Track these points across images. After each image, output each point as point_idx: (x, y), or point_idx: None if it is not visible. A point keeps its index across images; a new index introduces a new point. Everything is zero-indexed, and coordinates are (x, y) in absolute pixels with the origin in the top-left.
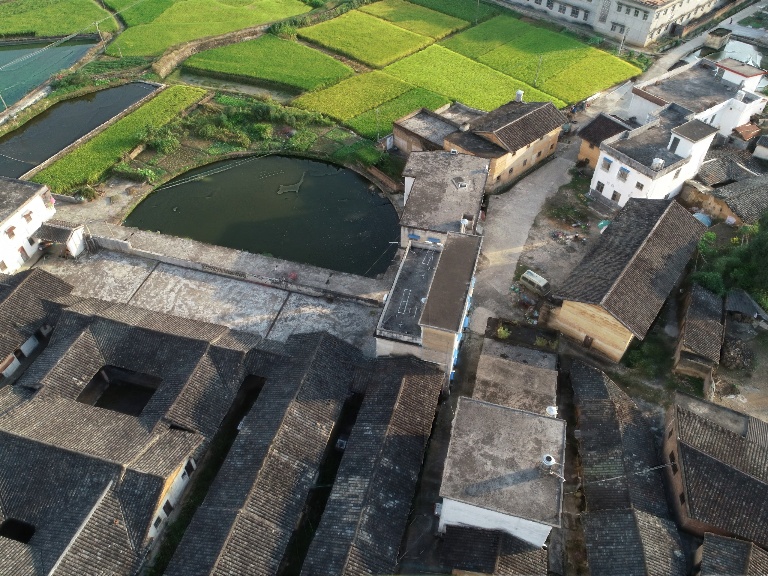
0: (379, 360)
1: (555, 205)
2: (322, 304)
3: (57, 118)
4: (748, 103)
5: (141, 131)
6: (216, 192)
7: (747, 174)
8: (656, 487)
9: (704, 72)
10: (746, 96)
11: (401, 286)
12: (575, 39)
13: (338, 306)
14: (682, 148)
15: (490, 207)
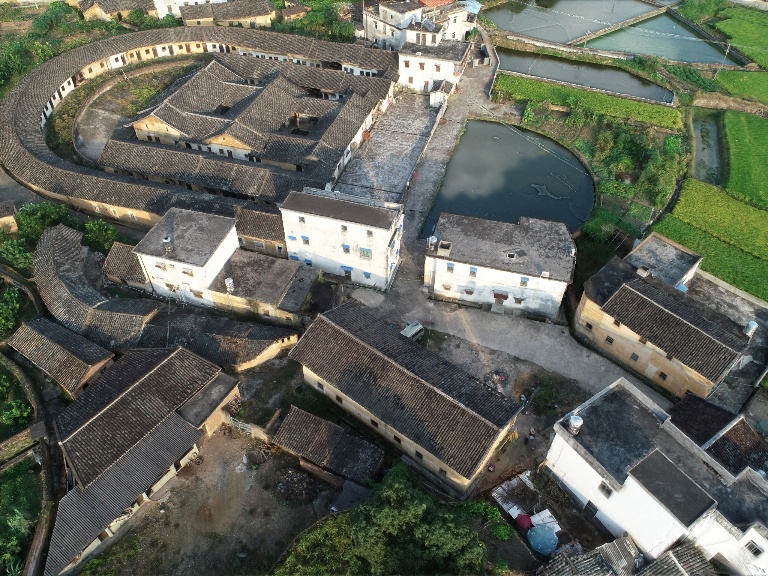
0: None
1: (561, 385)
2: None
3: (605, 75)
4: None
5: None
6: (526, 155)
7: None
8: None
9: None
10: None
11: None
12: None
13: None
14: None
15: (543, 324)
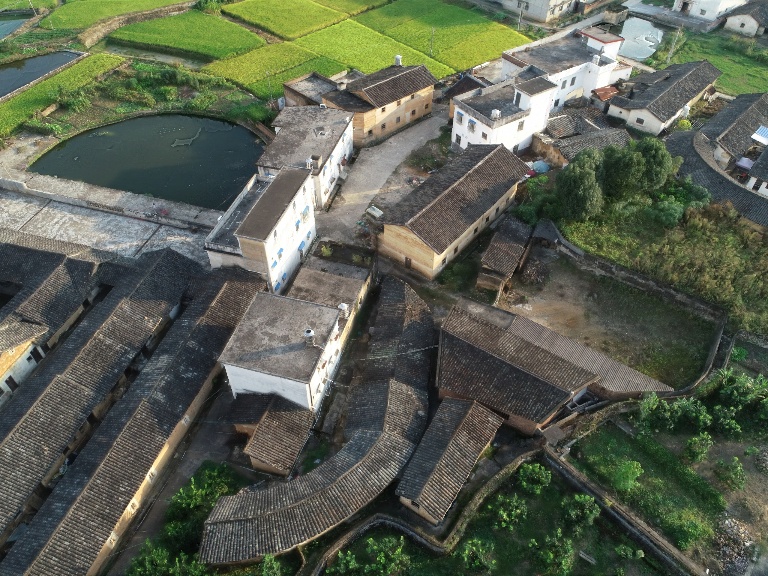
0: (213, 272)
1: (418, 156)
2: (187, 234)
3: None
4: (602, 66)
5: (53, 91)
6: (117, 145)
7: (591, 128)
8: (422, 368)
9: (575, 40)
10: (605, 61)
11: None
12: (481, 15)
13: (200, 236)
14: (523, 102)
15: (359, 157)
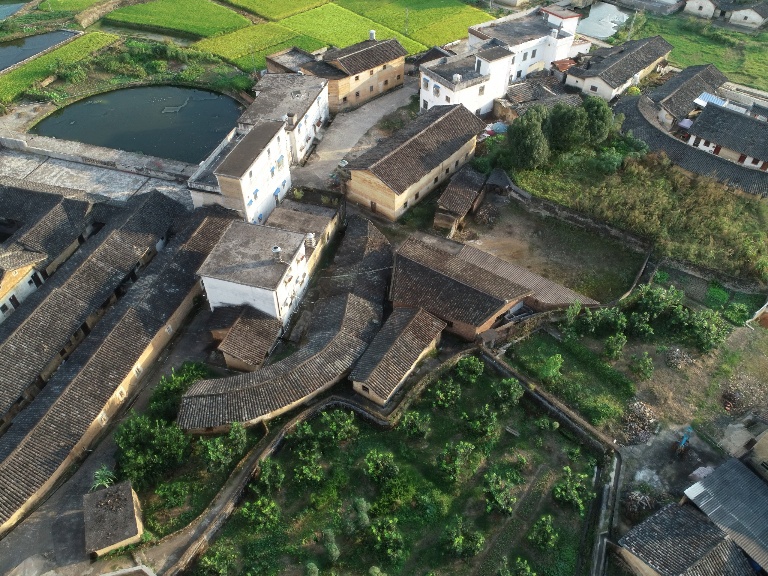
0: (195, 211)
1: (389, 120)
2: (174, 185)
3: None
4: (559, 39)
5: (52, 63)
6: (110, 112)
7: (548, 94)
8: (379, 287)
9: (538, 18)
10: (563, 35)
11: (219, 158)
12: None
13: (186, 186)
14: (483, 68)
15: (334, 121)
